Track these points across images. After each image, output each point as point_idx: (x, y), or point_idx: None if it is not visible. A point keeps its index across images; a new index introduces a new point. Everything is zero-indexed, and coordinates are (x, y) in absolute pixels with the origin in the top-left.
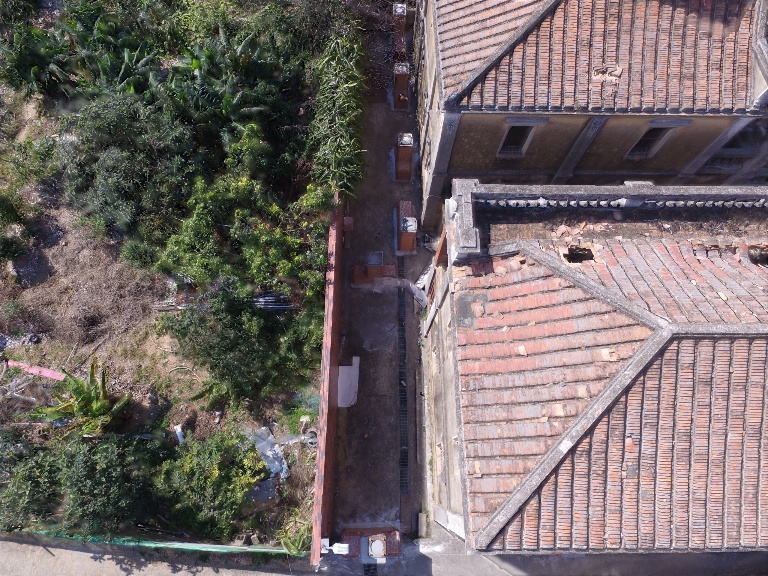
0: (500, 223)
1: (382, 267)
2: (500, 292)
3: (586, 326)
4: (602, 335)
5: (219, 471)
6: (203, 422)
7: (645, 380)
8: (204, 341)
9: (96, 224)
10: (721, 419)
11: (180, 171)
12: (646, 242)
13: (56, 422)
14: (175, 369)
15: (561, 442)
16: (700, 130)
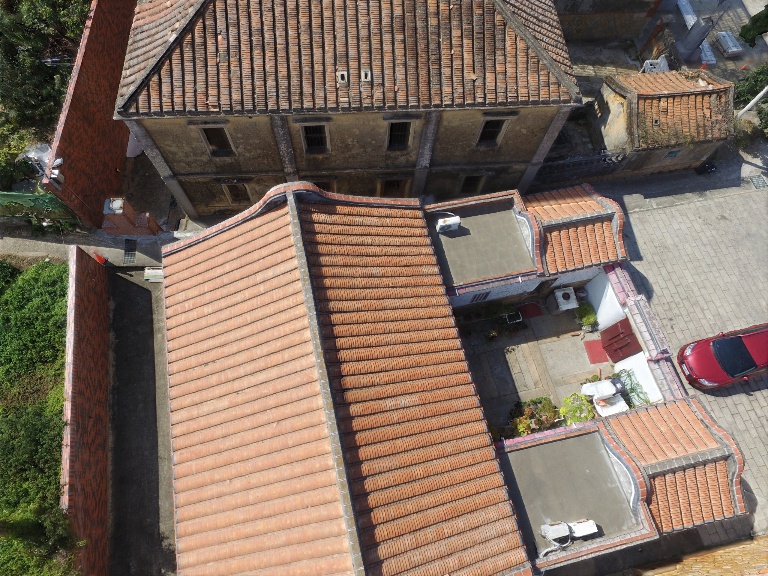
0: None
1: None
2: None
3: None
4: None
5: None
6: None
7: None
8: None
9: None
10: (281, 19)
11: None
12: None
13: None
14: None
15: None
16: None
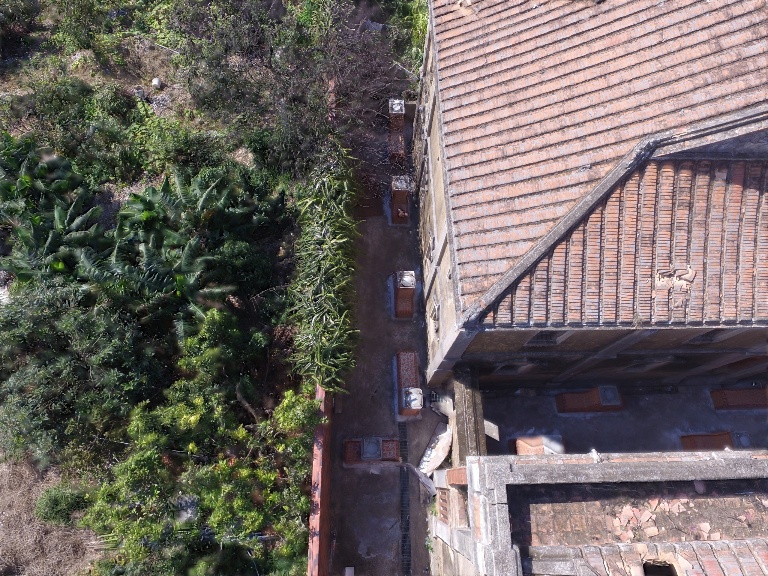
0: (543, 501)
1: None
2: None
3: None
4: None
5: None
6: None
7: None
8: None
9: (14, 440)
10: None
11: (118, 387)
12: (749, 550)
13: None
14: None
15: None
16: None
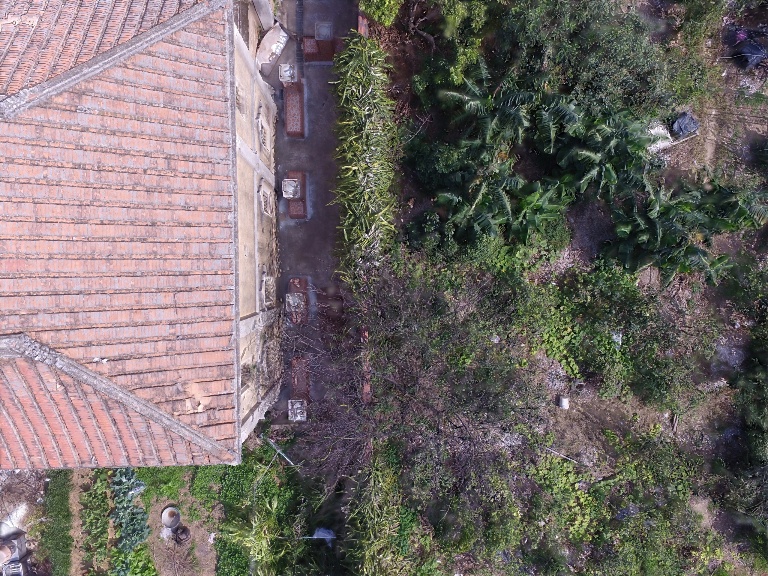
0: None
1: None
2: None
3: None
4: None
5: None
6: None
7: None
8: None
9: None
10: None
11: None
12: None
13: None
14: None
15: None
16: None
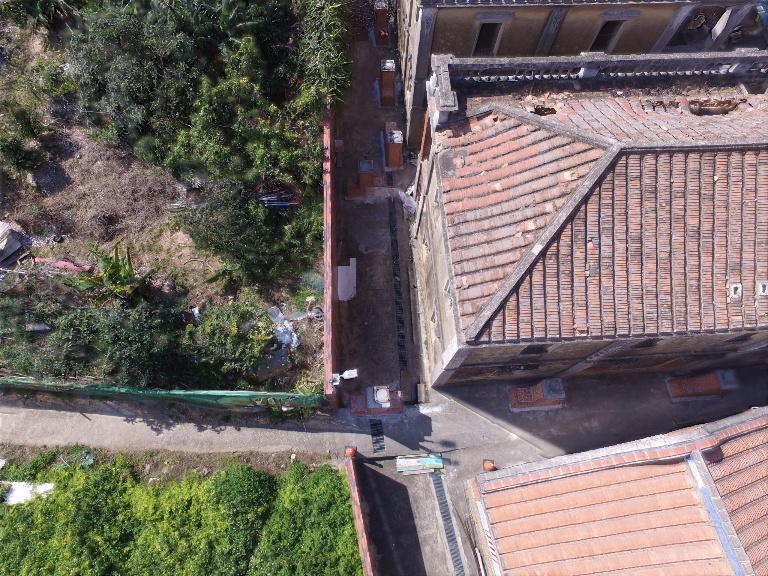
0: (475, 96)
1: (373, 175)
2: (477, 146)
3: (551, 157)
4: (564, 161)
5: (237, 329)
6: (218, 305)
7: (601, 191)
8: (216, 226)
9: (109, 135)
10: (665, 222)
11: (185, 77)
12: (601, 101)
13: (88, 291)
14: (189, 261)
15: (533, 247)
16: (649, 23)
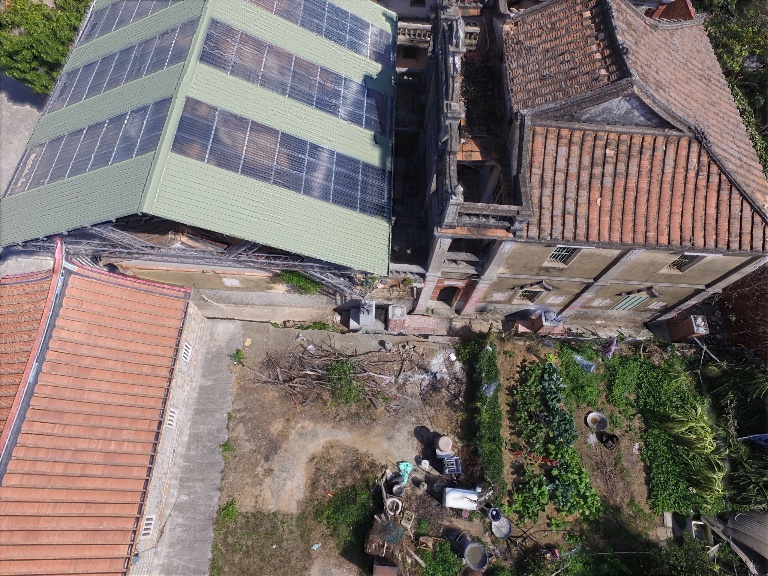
0: None
1: None
2: None
3: None
4: None
5: None
6: None
7: None
8: None
9: None
10: None
11: None
12: None
13: None
14: None
15: None
16: None
